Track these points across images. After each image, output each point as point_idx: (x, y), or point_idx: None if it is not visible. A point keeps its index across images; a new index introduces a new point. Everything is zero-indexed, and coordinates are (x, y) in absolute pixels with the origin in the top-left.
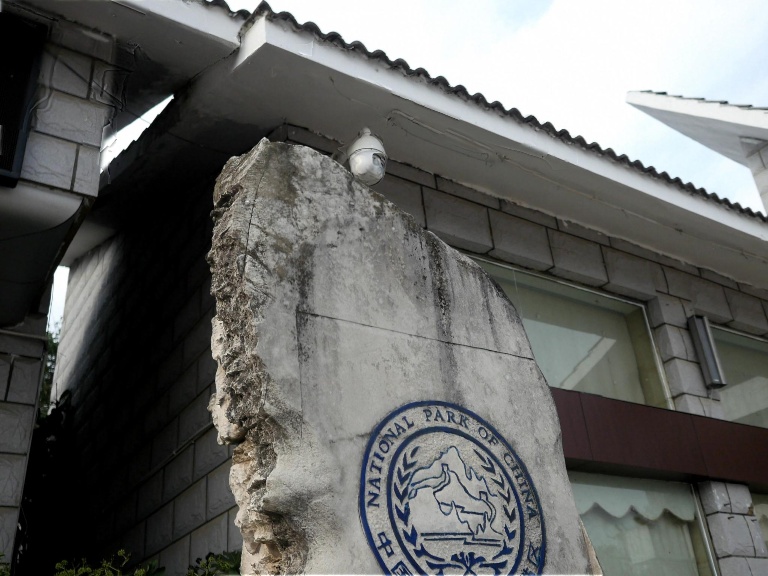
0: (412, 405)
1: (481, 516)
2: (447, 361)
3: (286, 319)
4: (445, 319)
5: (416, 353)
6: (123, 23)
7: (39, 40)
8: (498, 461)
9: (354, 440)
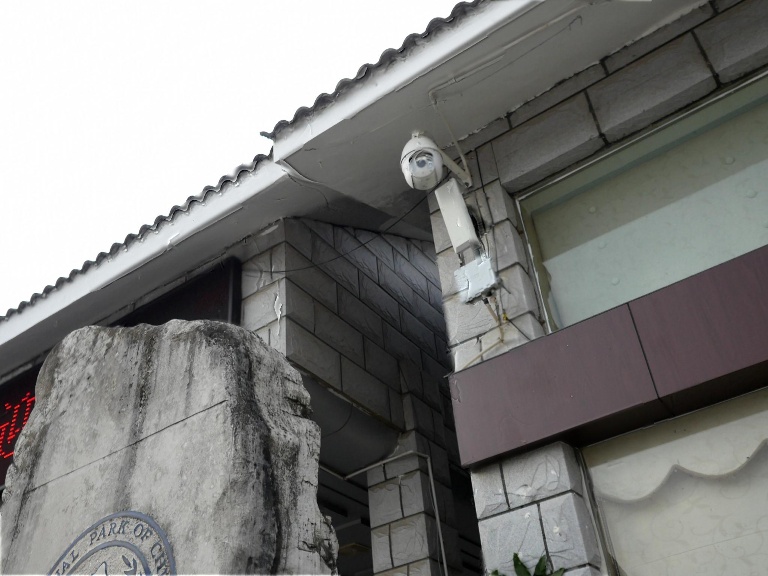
0: (83, 534)
1: None
2: (127, 465)
3: None
4: (141, 417)
5: (103, 474)
6: (245, 222)
7: (221, 276)
8: (143, 558)
9: None
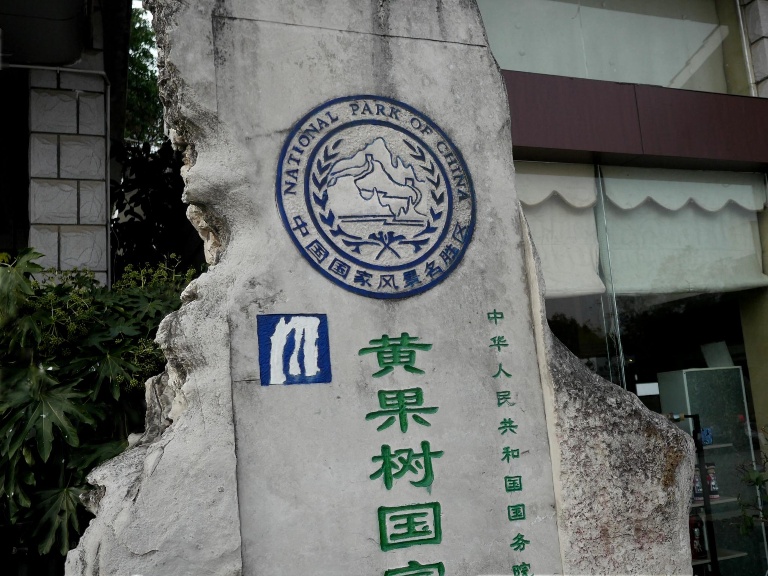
0: (337, 100)
1: (405, 200)
2: (381, 55)
3: (201, 24)
4: (383, 11)
5: (346, 49)
6: None
7: None
8: (430, 149)
9: (272, 136)
